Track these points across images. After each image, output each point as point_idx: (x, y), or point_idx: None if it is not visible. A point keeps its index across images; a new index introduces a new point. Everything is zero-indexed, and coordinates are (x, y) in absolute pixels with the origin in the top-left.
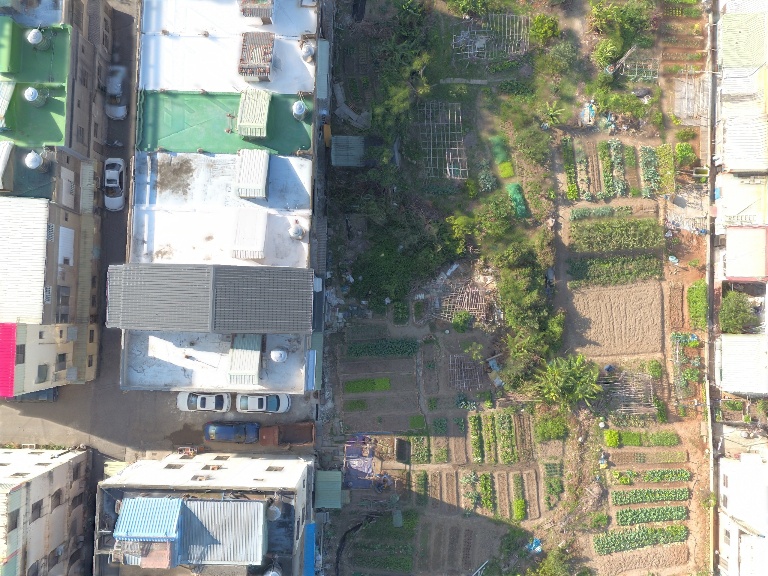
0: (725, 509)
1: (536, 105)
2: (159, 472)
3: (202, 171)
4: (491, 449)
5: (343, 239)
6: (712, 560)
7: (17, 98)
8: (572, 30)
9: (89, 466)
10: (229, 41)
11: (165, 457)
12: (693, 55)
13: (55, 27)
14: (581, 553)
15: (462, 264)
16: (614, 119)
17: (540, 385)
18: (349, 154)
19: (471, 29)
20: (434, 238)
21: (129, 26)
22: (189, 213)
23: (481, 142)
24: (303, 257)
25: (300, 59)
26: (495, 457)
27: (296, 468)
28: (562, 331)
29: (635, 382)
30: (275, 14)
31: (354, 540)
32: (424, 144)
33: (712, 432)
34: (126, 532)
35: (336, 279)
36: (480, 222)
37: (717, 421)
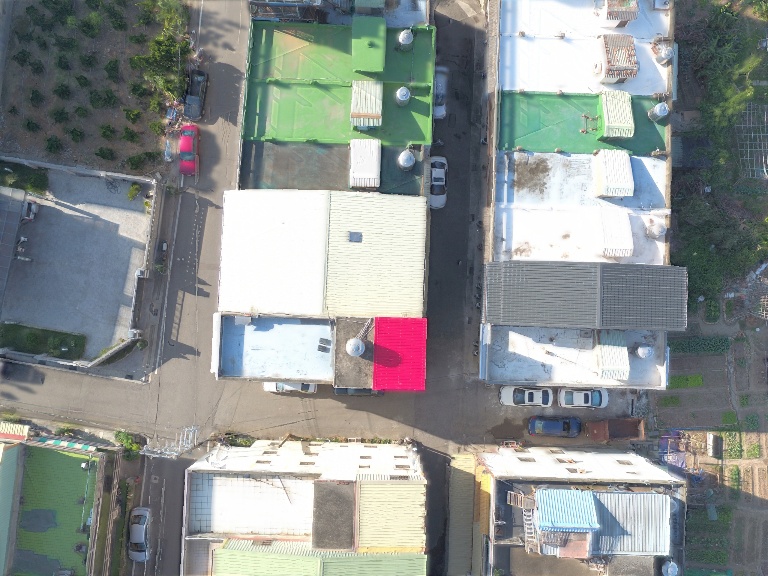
0: None
1: None
2: (526, 465)
3: (558, 170)
4: None
5: None
6: None
7: (385, 97)
8: None
9: (415, 459)
10: (584, 43)
11: (498, 450)
12: None
13: (420, 28)
14: None
15: None
16: None
17: None
18: None
19: None
20: (754, 238)
21: (445, 26)
22: (546, 211)
23: None
24: (657, 255)
25: (652, 61)
26: None
27: (641, 462)
28: None
29: None
30: None
31: None
32: (741, 145)
33: None
34: (551, 522)
35: None
36: None
37: None
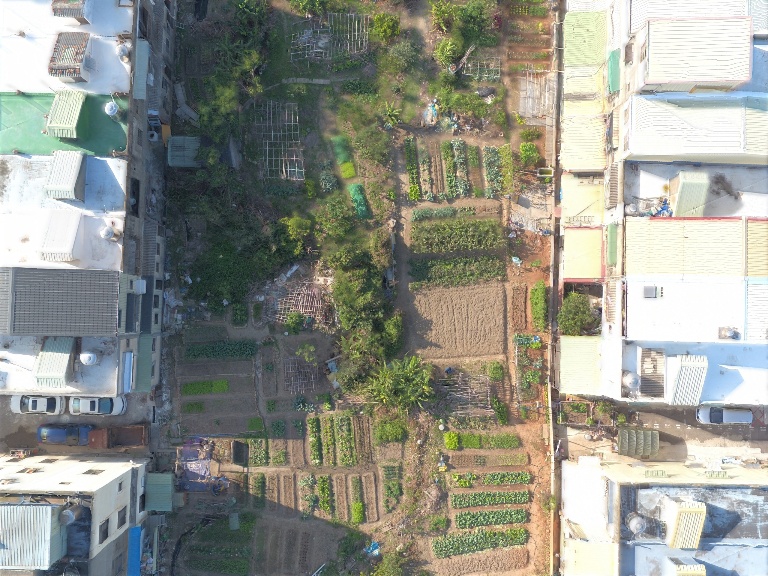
0: (563, 512)
1: (379, 105)
2: None
3: (18, 173)
4: (329, 452)
5: (182, 240)
6: (552, 563)
7: None
8: (417, 29)
9: None
10: (46, 41)
11: None
12: (539, 54)
13: None
14: (419, 556)
15: (302, 265)
16: (457, 119)
17: (372, 387)
18: (185, 155)
19: (314, 28)
20: (268, 239)
21: None
22: (5, 215)
23: (323, 142)
24: (119, 259)
25: (118, 59)
26: (333, 460)
27: (117, 471)
28: (398, 333)
29: (476, 384)
30: (92, 14)
31: (190, 543)
32: (260, 145)
33: (553, 434)
34: None
35: (175, 281)
36: (321, 223)
37: (558, 423)
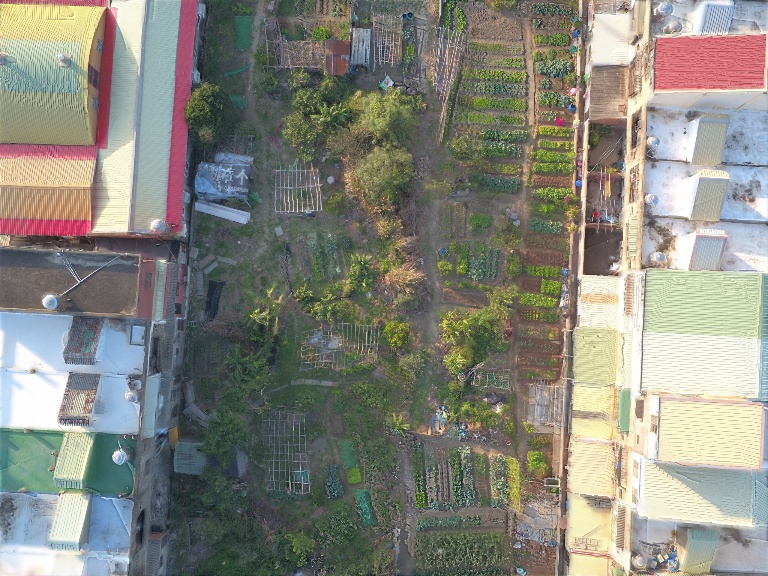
0: None
1: (387, 409)
2: None
3: (23, 511)
4: None
5: (185, 544)
6: None
7: None
8: (427, 332)
9: None
10: (56, 378)
11: None
12: (548, 361)
13: None
14: None
15: (305, 573)
16: (464, 428)
17: None
18: (191, 463)
19: (324, 329)
20: (272, 556)
21: None
22: (8, 554)
23: (330, 446)
24: None
25: None
26: None
27: None
28: None
29: None
30: None
31: None
32: (267, 456)
33: None
34: None
35: None
36: None
37: None
